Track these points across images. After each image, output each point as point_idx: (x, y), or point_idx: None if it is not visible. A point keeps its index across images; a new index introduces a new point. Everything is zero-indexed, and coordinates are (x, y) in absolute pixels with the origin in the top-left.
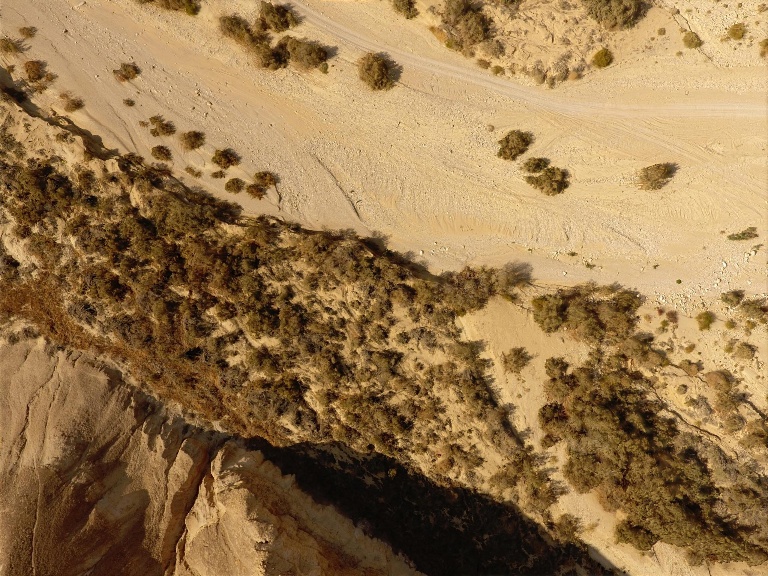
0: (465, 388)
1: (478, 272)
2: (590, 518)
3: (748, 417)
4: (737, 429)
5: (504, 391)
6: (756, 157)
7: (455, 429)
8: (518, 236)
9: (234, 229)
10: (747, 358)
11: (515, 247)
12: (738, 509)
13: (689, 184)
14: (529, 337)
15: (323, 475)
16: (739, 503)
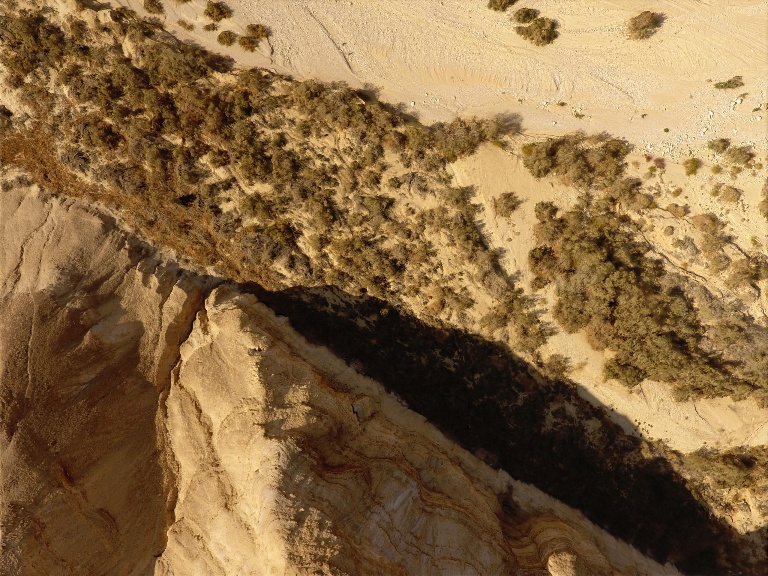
0: (456, 230)
1: (469, 122)
2: (579, 357)
3: (733, 257)
4: (722, 268)
5: (494, 235)
6: (742, 7)
7: (446, 272)
8: (508, 86)
9: (227, 78)
10: (733, 201)
11: (505, 98)
12: (723, 344)
13: (676, 34)
14: (519, 182)
15: (316, 318)
16: (724, 338)
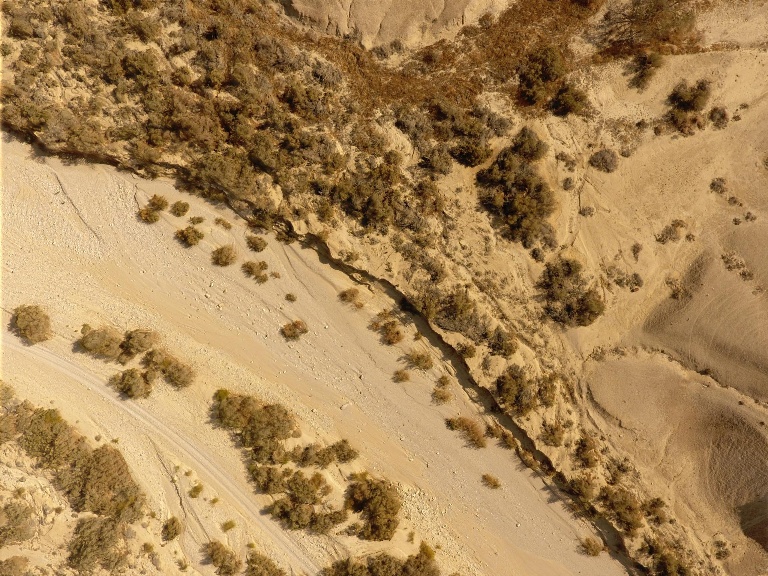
0: None
1: None
2: None
3: None
4: None
5: None
6: None
7: None
8: None
9: (172, 160)
10: None
11: None
12: None
13: None
14: None
15: None
16: None
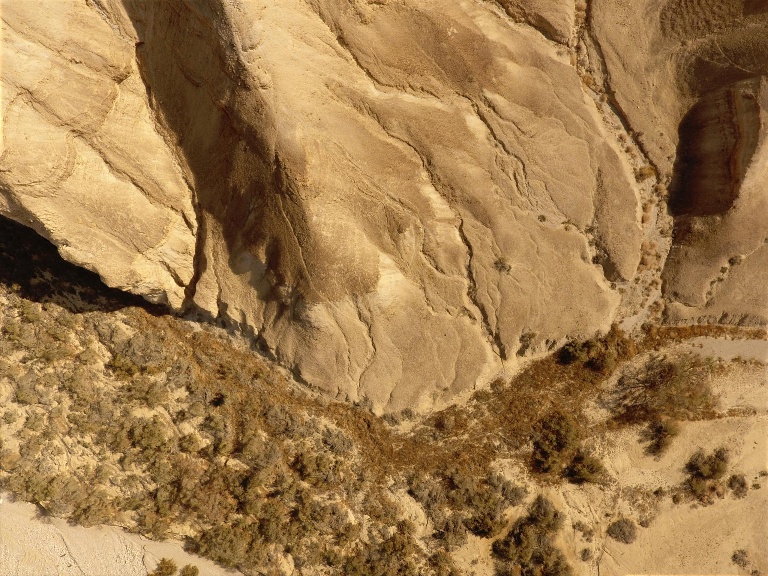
0: None
1: None
2: None
3: None
4: None
5: None
6: None
7: None
8: None
9: (181, 531)
10: None
11: None
12: None
13: None
14: None
15: (91, 280)
16: None
